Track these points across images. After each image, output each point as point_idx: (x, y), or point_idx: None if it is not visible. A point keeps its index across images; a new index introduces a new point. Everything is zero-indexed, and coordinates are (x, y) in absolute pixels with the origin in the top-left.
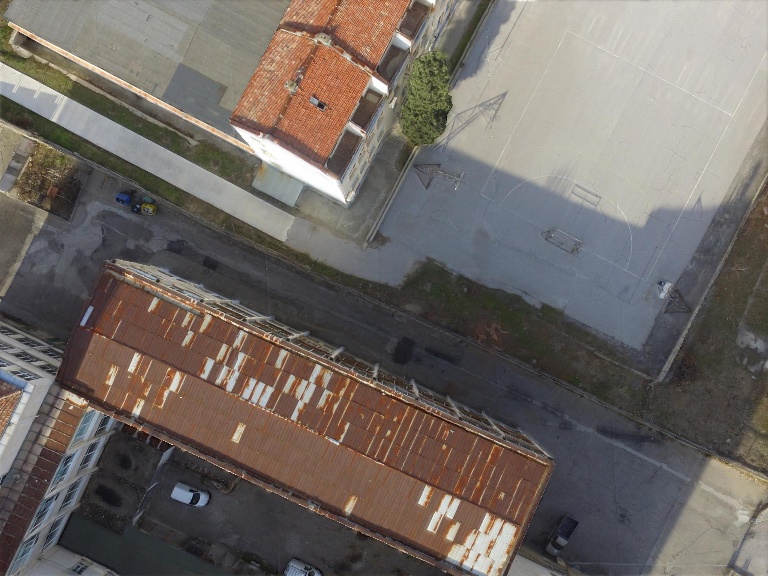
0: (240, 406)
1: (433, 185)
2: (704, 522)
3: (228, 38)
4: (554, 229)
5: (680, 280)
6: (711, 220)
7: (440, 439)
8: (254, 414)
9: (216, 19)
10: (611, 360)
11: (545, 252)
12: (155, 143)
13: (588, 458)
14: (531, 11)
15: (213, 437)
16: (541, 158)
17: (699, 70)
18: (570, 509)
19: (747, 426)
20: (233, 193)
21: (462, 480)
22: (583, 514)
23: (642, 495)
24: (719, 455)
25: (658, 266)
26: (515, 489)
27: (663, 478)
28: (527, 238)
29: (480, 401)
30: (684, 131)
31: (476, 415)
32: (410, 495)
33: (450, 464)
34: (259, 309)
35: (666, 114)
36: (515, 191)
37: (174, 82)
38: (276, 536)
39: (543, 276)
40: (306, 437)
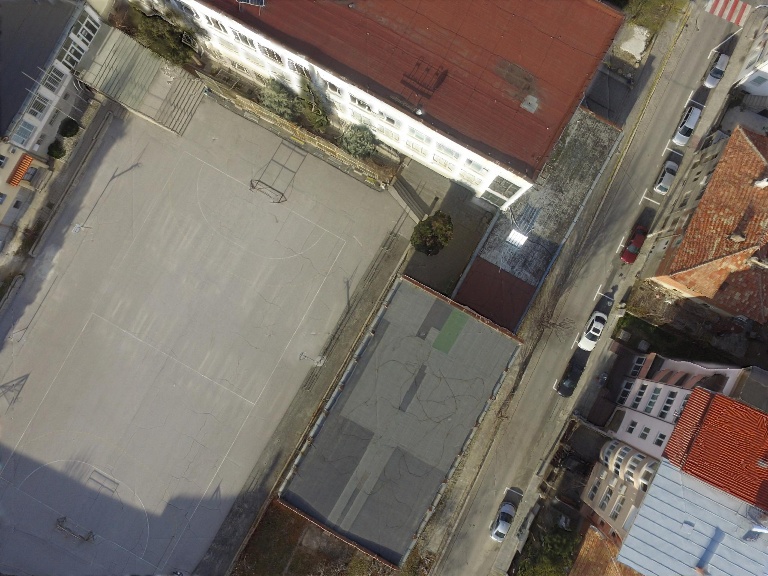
0: None
1: None
2: None
3: None
4: (71, 515)
5: (197, 570)
6: (230, 509)
7: None
8: None
9: None
10: None
11: (61, 538)
12: None
13: None
14: (58, 292)
15: None
16: (61, 442)
17: (223, 357)
18: None
19: None
20: None
21: None
22: None
23: None
24: None
25: (174, 555)
26: None
27: None
28: (43, 523)
29: None
30: (205, 418)
31: None
32: None
33: None
34: None
35: (188, 400)
36: (34, 475)
37: None
38: None
39: (58, 563)
40: None
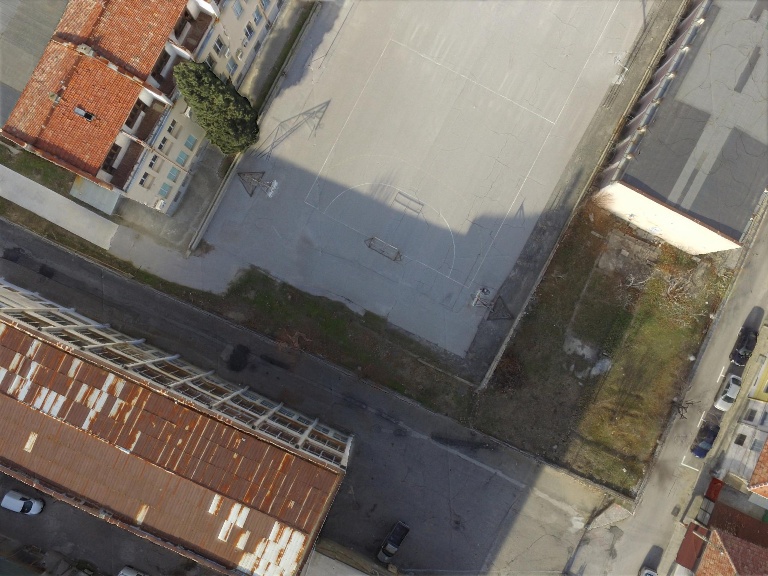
0: (32, 415)
1: (257, 193)
2: (539, 528)
3: (30, 48)
4: (377, 236)
5: (503, 287)
6: (533, 227)
7: (231, 448)
8: (46, 423)
9: (19, 29)
10: (434, 367)
11: (368, 259)
12: None
13: (423, 465)
14: (354, 19)
15: (6, 446)
16: (364, 166)
17: (521, 78)
18: (404, 516)
19: (574, 432)
20: (56, 201)
21: (252, 489)
22: (417, 521)
23: (476, 502)
24: (546, 461)
25: (481, 273)
26: (305, 497)
27: (497, 484)
28: (350, 245)
29: (315, 408)
30: (506, 138)
31: (296, 422)
32: (200, 504)
33: (241, 473)
34: (95, 317)
35: (488, 122)
36: (339, 199)
37: None
38: (111, 544)
39: (366, 283)
40: (97, 446)
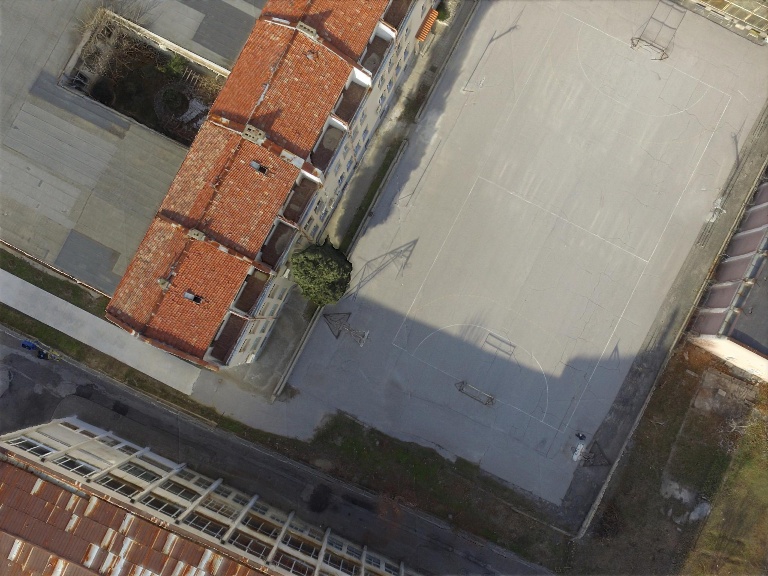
0: None
1: (343, 334)
2: None
3: (122, 204)
4: (468, 379)
5: (598, 431)
6: (629, 369)
7: None
8: None
9: (110, 184)
10: (529, 516)
11: (459, 403)
12: (56, 296)
13: None
14: (442, 157)
15: None
16: (454, 306)
17: (613, 215)
18: None
19: None
20: (137, 346)
21: None
22: None
23: None
24: None
25: (575, 417)
26: None
27: None
28: (440, 389)
29: (399, 551)
30: (599, 278)
31: None
32: None
33: None
34: (170, 455)
35: (580, 261)
36: (427, 340)
37: (66, 248)
38: None
39: (457, 428)
40: None
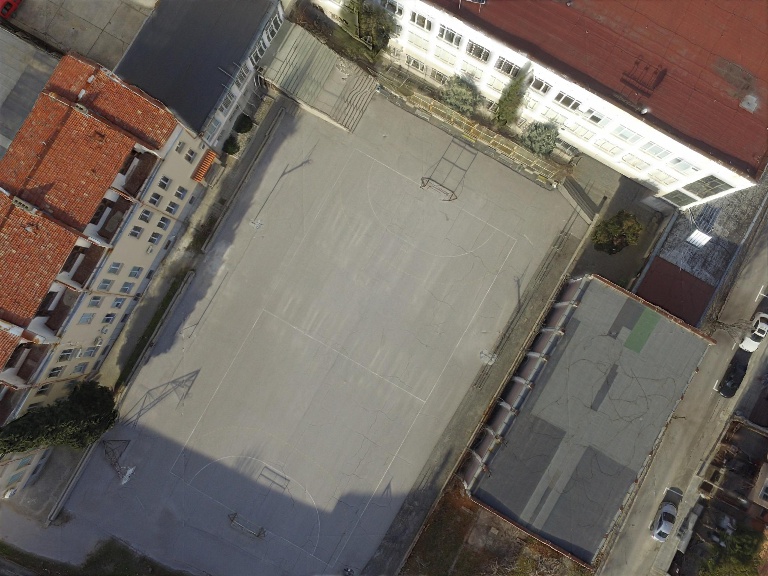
0: None
1: (122, 461)
2: None
3: None
4: (242, 511)
5: (367, 567)
6: (400, 507)
7: None
8: None
9: None
10: None
11: (232, 534)
12: None
13: None
14: (228, 288)
15: None
16: (232, 438)
17: (393, 354)
18: None
19: None
20: None
21: None
22: None
23: None
24: None
25: (345, 552)
26: None
27: None
28: (214, 519)
29: None
30: (376, 415)
31: None
32: None
33: None
34: None
35: (358, 398)
36: (204, 470)
37: None
38: None
39: (229, 559)
40: None
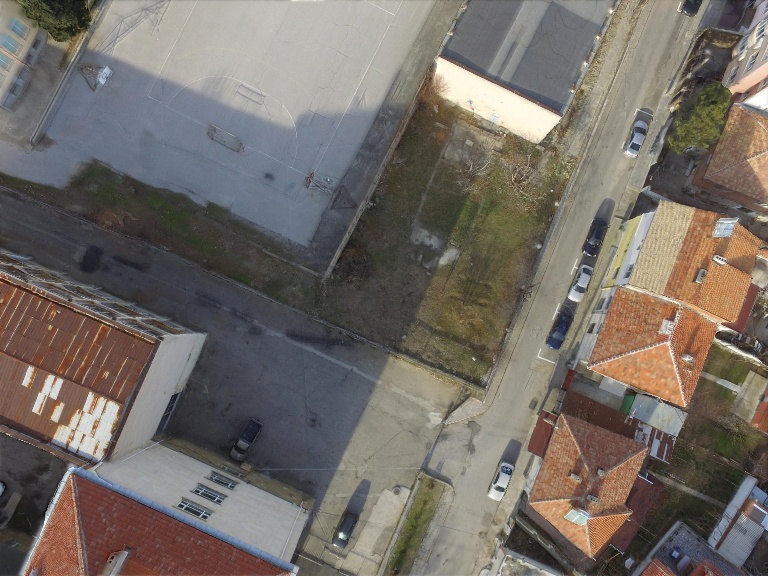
0: None
1: (100, 88)
2: (396, 425)
3: None
4: None
5: (346, 176)
6: (375, 117)
7: (46, 320)
8: None
9: None
10: (279, 257)
11: (212, 151)
12: None
13: (278, 363)
14: None
15: None
16: (207, 59)
17: None
18: (259, 414)
19: (423, 322)
20: None
21: (66, 360)
22: (273, 419)
23: (332, 399)
24: (395, 352)
25: (324, 163)
26: (120, 368)
27: (353, 381)
28: (194, 138)
29: (168, 308)
30: (347, 30)
31: (137, 313)
32: (14, 377)
33: (55, 344)
34: None
35: (329, 14)
36: (182, 92)
37: None
38: None
39: (210, 175)
40: None
